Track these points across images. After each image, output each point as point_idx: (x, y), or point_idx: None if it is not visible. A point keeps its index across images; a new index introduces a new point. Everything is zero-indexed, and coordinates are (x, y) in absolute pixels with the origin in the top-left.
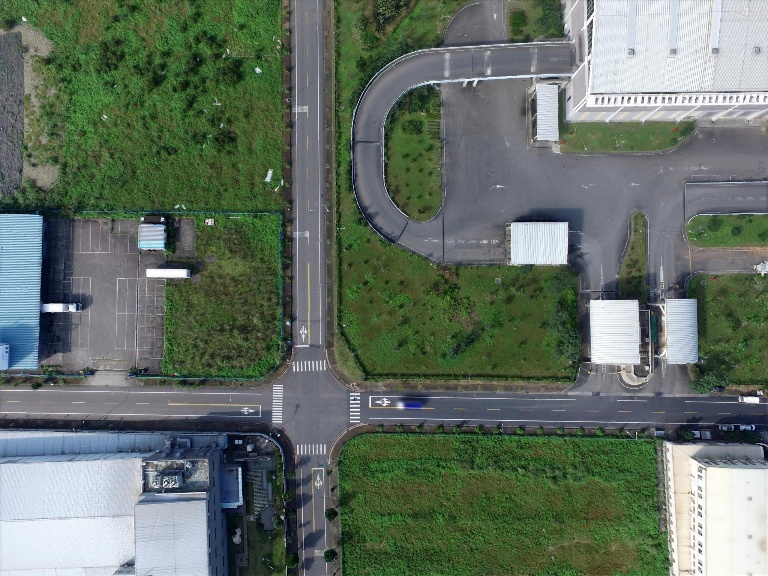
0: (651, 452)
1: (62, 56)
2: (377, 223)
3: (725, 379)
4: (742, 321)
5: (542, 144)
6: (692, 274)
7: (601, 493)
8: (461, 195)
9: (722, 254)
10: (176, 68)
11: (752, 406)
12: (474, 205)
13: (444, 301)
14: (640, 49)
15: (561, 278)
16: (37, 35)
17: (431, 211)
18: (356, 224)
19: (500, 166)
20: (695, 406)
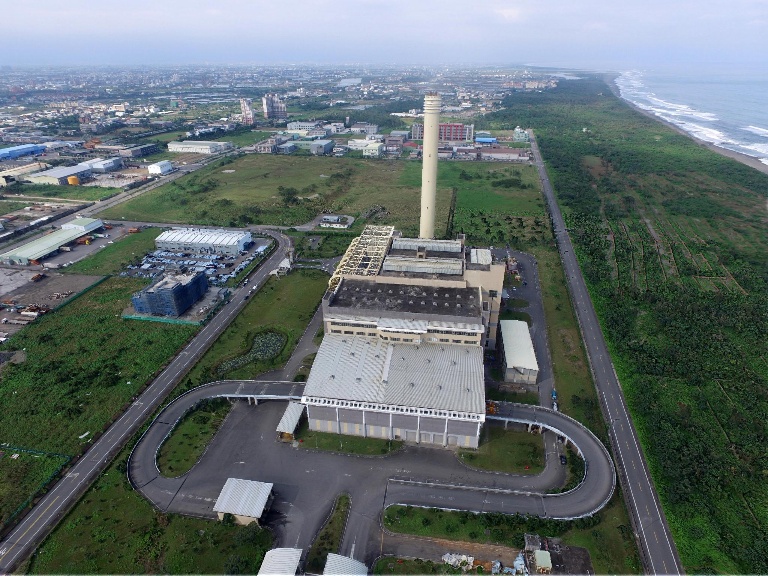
0: None
1: (25, 364)
2: (134, 473)
3: None
4: None
5: (286, 440)
6: (382, 555)
7: None
8: (210, 464)
9: (413, 541)
10: (82, 376)
11: None
12: (216, 472)
13: (142, 540)
14: (338, 376)
15: (248, 527)
16: (23, 355)
17: (180, 471)
18: (117, 472)
19: (250, 450)
20: None
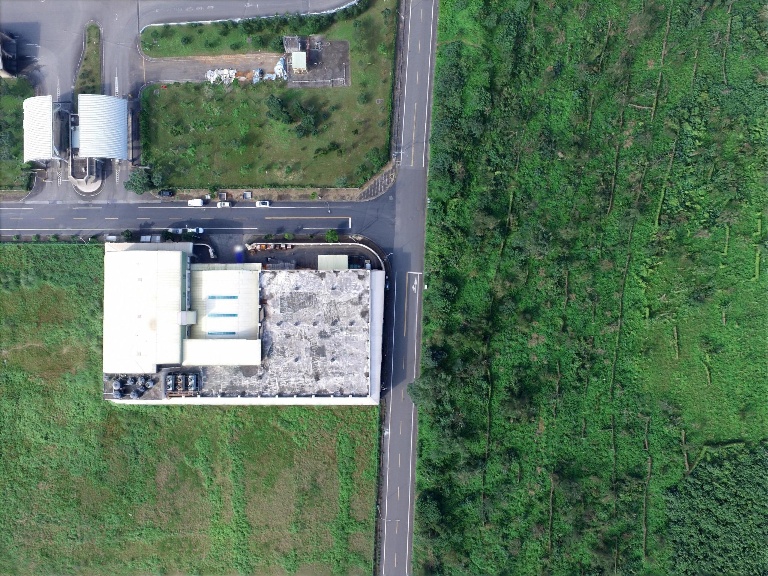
0: (100, 256)
1: None
2: None
3: (155, 177)
4: (190, 127)
5: None
6: (146, 84)
7: (53, 297)
8: None
9: (175, 64)
10: None
11: (203, 210)
12: None
13: None
14: None
15: None
16: None
17: None
18: None
19: None
20: (148, 212)
